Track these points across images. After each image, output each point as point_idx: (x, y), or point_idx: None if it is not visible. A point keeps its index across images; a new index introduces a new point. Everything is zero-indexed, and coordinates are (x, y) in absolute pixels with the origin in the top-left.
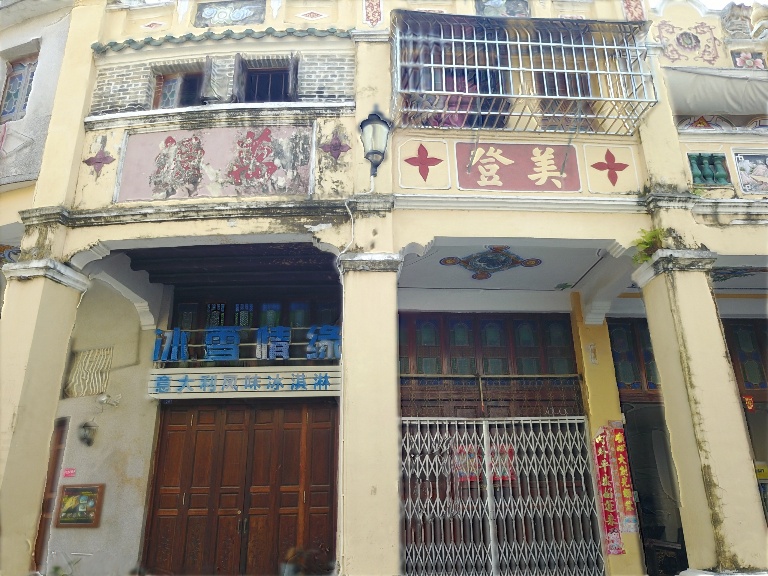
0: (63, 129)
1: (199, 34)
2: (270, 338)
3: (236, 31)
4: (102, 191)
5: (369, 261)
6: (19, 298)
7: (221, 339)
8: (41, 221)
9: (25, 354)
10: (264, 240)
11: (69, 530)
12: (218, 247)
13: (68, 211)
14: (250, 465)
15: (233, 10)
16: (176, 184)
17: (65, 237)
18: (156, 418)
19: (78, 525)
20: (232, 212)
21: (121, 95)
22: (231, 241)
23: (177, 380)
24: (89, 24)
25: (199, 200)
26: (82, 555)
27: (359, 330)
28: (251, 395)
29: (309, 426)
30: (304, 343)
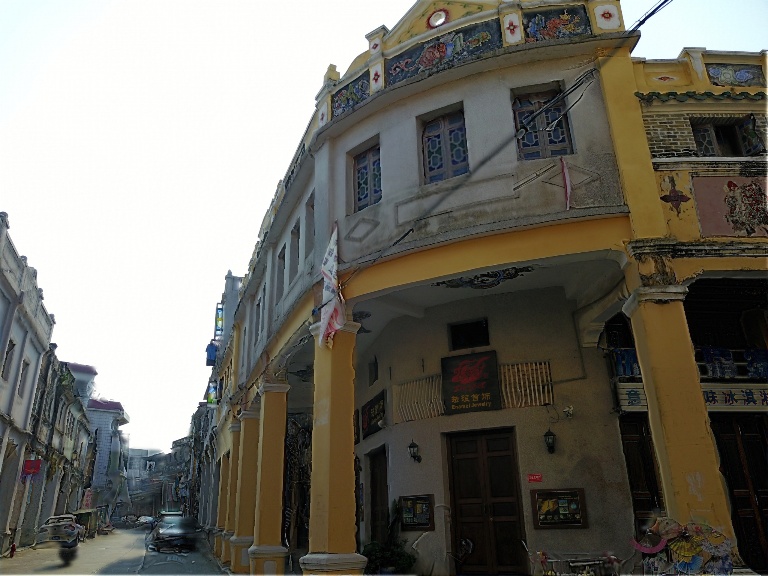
0: (637, 168)
1: None
2: (714, 358)
3: (754, 92)
4: (688, 226)
5: None
6: (662, 319)
7: None
8: (653, 250)
9: (693, 369)
10: None
11: (553, 531)
12: None
13: None
14: None
15: (734, 72)
16: (753, 224)
17: None
18: None
19: (563, 526)
20: None
21: (672, 141)
22: None
23: None
24: (623, 74)
25: None
26: (577, 554)
27: None
28: None
29: (743, 437)
30: (743, 363)
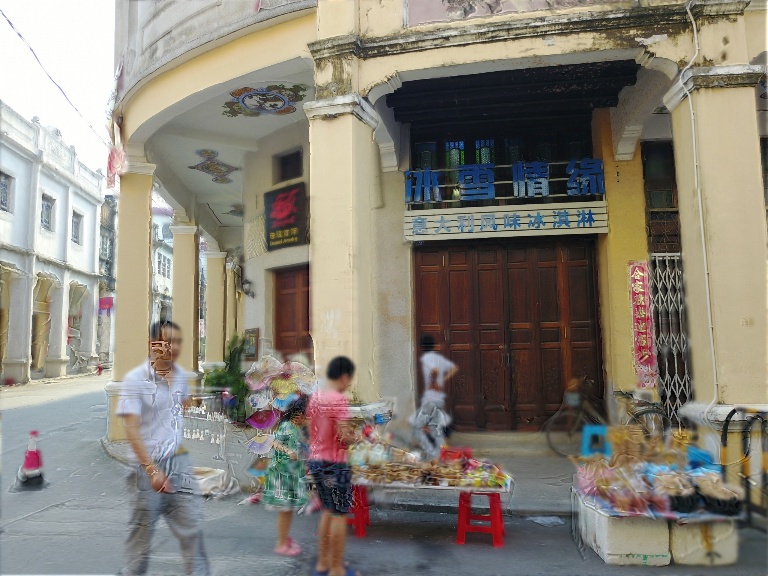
0: None
1: None
2: (526, 175)
3: None
4: (390, 15)
5: (725, 75)
6: (327, 138)
7: (474, 178)
8: (333, 53)
9: (348, 195)
10: (581, 60)
11: None
12: (506, 73)
13: (360, 40)
14: (507, 303)
15: None
16: None
17: (358, 70)
18: (410, 260)
19: None
20: (549, 28)
21: None
22: (543, 63)
23: (432, 221)
24: None
25: (507, 17)
26: None
27: (717, 155)
28: (506, 234)
29: (564, 264)
30: (563, 179)
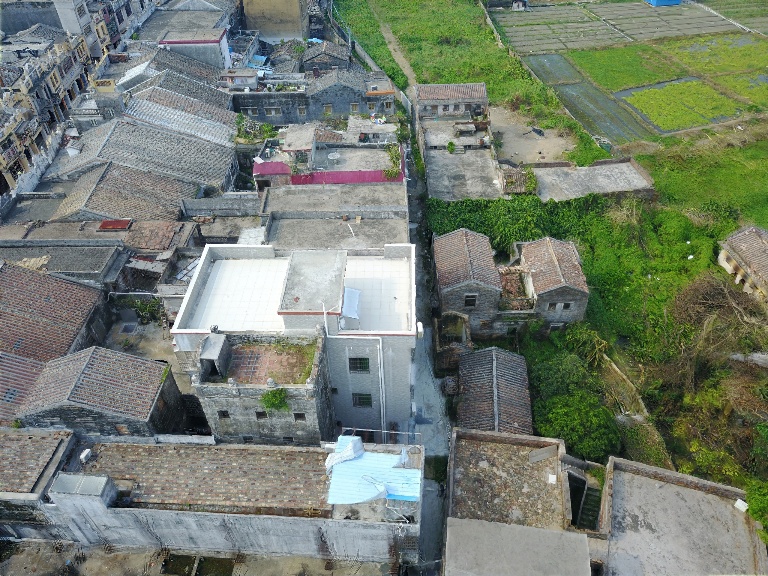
0: None
1: (2, 140)
2: None
3: (4, 138)
4: None
5: None
6: None
7: None
8: None
9: None
10: None
11: None
12: None
13: None
14: None
15: None
16: None
17: None
18: None
19: None
20: None
21: None
22: None
23: None
24: None
25: None
26: None
27: None
28: None
29: None
30: None
